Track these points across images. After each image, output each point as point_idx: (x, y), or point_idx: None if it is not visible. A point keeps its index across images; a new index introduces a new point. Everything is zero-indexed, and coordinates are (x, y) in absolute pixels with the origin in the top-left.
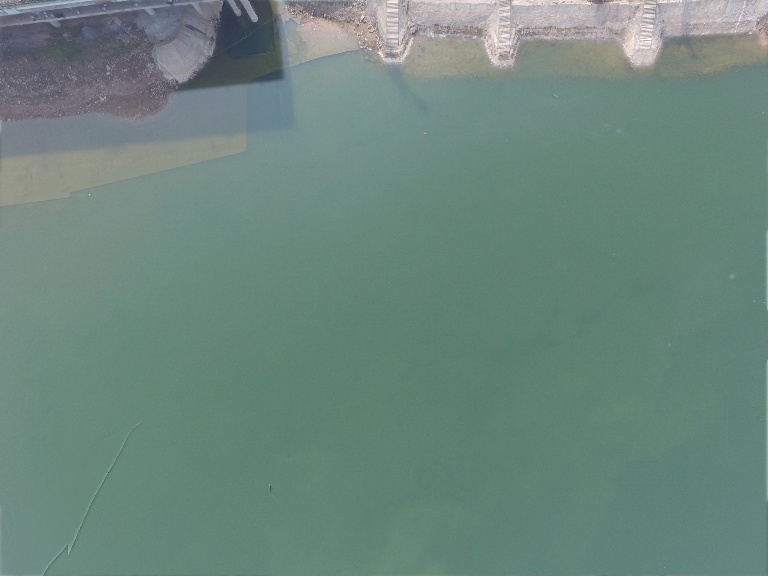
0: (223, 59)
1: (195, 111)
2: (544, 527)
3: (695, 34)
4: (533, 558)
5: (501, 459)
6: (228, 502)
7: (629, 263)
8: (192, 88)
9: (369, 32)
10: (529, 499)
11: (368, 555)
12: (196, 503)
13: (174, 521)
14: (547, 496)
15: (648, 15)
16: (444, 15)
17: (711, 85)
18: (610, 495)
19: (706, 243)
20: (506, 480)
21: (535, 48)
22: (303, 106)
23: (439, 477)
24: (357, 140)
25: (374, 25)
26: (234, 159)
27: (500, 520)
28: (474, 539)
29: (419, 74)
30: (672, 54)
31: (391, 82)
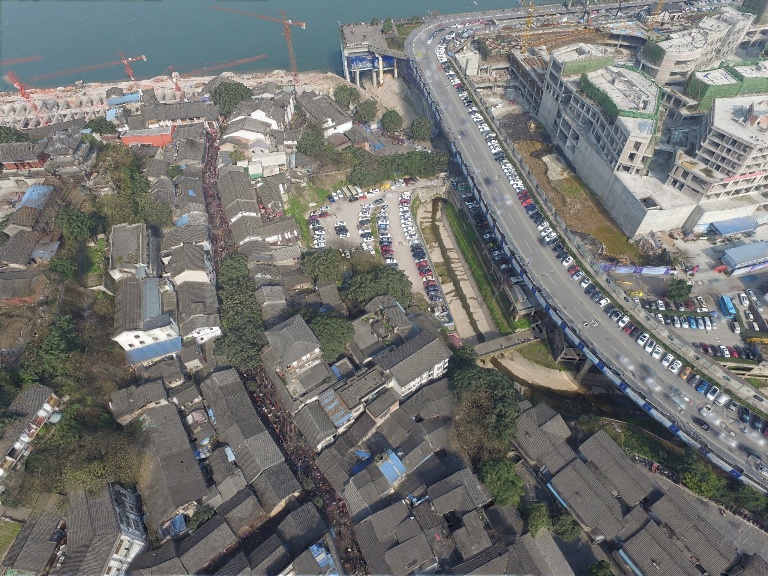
0: None
1: None
2: None
3: None
4: None
5: (250, 3)
6: None
7: None
8: None
9: None
10: None
11: None
12: None
13: None
14: None
15: None
16: None
17: None
18: (211, 0)
19: None
20: None
21: None
22: None
23: None
24: None
25: None
26: None
27: None
28: None
29: None
30: None
31: (281, 66)
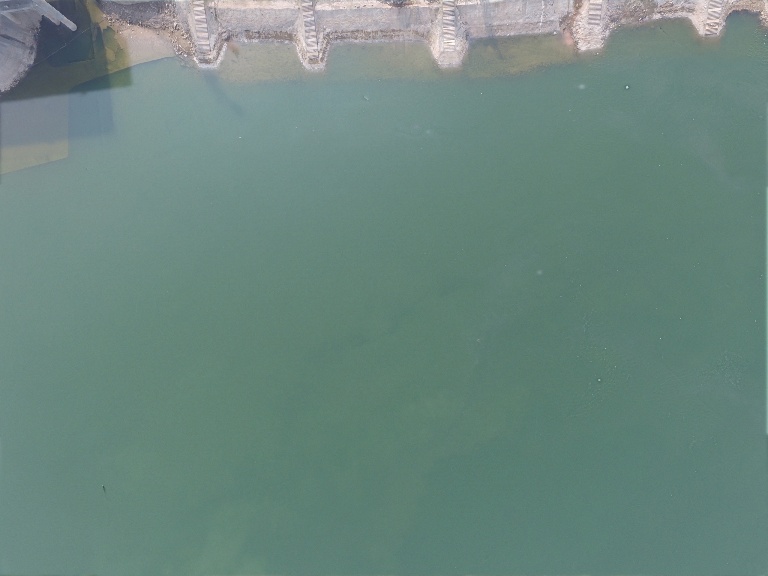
0: (44, 67)
1: (18, 119)
2: (362, 524)
3: (501, 35)
4: (352, 555)
5: (319, 457)
6: (56, 503)
7: (440, 262)
8: (15, 96)
9: (183, 39)
10: (347, 497)
11: (188, 554)
12: (26, 504)
13: (6, 522)
14: (364, 494)
15: (448, 17)
16: (252, 21)
17: (517, 85)
18: (425, 492)
19: (515, 241)
20: (324, 478)
21: (346, 51)
22: (122, 112)
23: (257, 476)
24: (175, 145)
25: (187, 32)
26: (56, 165)
27: (319, 518)
28: (294, 537)
29: (234, 79)
30: (479, 55)
31: (206, 87)
